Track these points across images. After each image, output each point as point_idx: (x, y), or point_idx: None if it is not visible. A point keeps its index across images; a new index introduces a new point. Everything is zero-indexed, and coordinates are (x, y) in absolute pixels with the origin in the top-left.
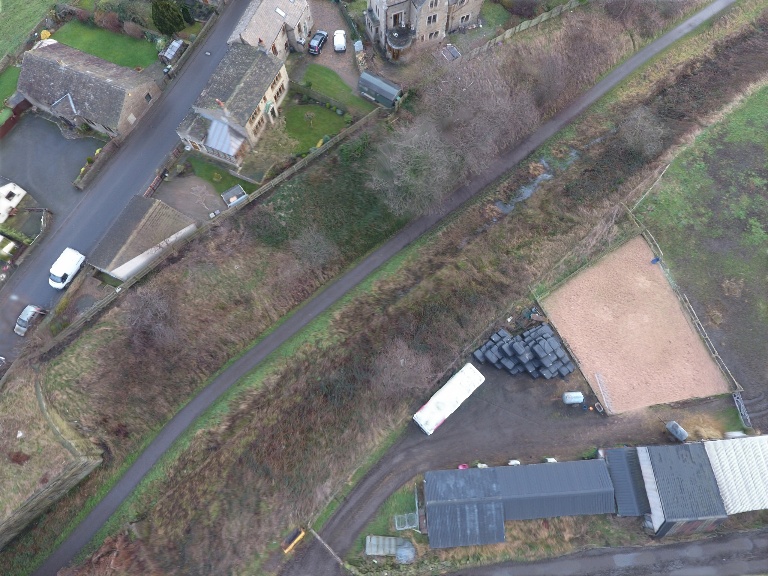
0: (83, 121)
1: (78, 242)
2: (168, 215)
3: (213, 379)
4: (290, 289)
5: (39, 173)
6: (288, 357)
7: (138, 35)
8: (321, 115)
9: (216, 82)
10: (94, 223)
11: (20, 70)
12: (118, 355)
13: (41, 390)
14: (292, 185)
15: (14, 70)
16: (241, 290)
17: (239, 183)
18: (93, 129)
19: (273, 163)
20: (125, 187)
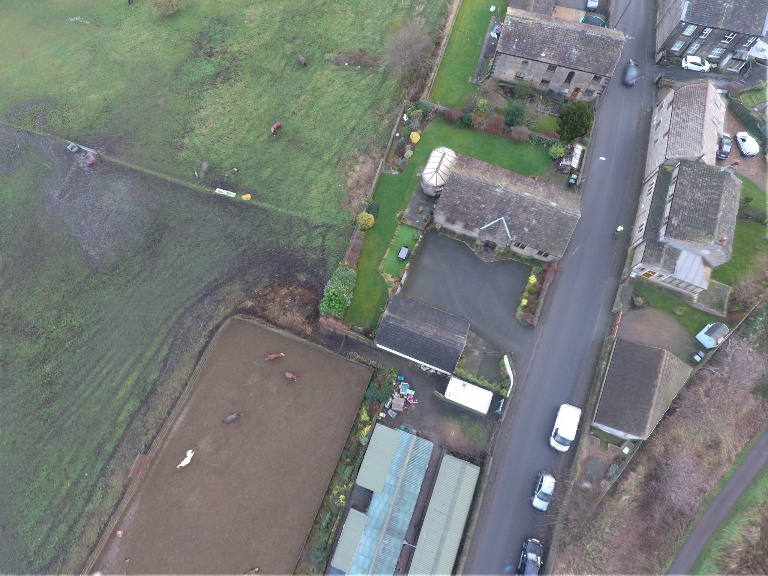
0: (508, 244)
1: (555, 391)
2: (675, 366)
3: (689, 533)
4: (746, 426)
5: (470, 304)
6: (759, 504)
7: (525, 139)
8: (759, 232)
9: (686, 209)
10: (563, 367)
11: (399, 178)
12: (630, 523)
13: (575, 573)
14: (762, 318)
15: (391, 178)
16: (711, 434)
17: (701, 315)
18: (510, 250)
19: (728, 291)
20: (579, 322)
